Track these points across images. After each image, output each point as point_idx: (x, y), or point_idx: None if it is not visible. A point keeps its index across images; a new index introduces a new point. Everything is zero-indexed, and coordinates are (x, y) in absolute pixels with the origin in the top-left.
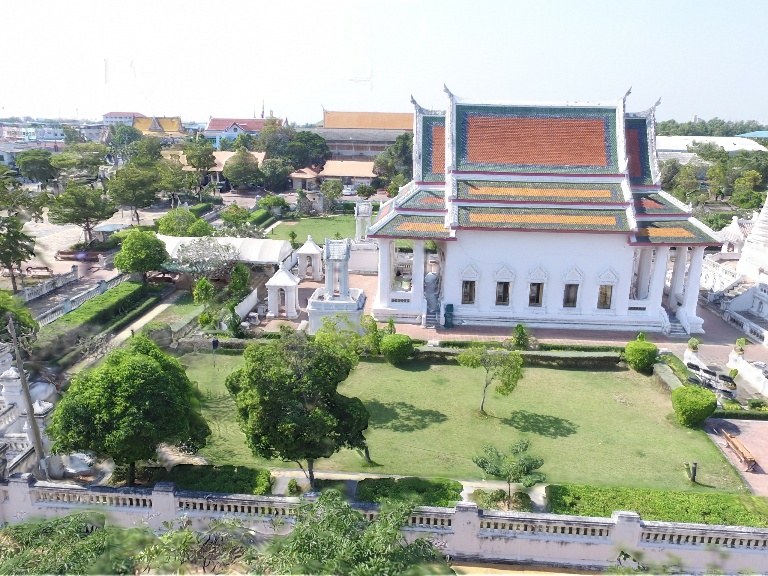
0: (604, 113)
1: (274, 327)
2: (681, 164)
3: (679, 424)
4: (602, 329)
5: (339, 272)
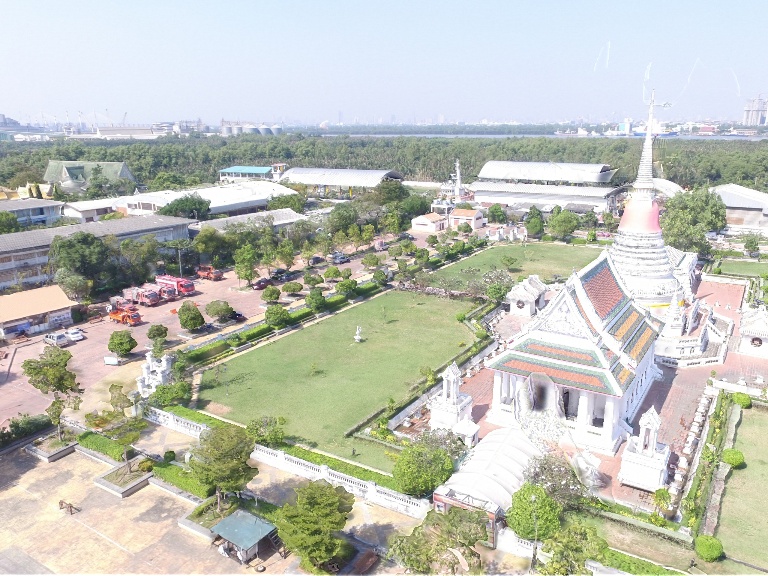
0: None
1: (618, 499)
2: (305, 223)
3: None
4: (648, 392)
5: (657, 432)
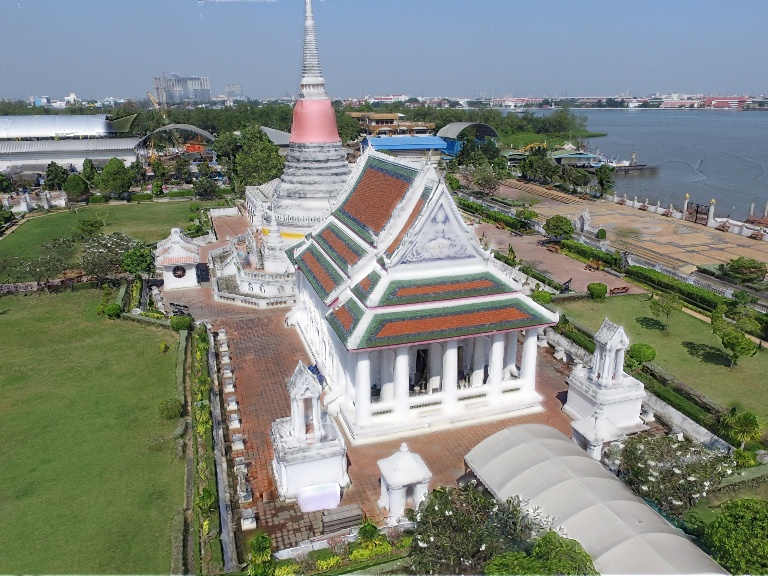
0: None
1: None
2: None
3: (603, 301)
4: None
5: None
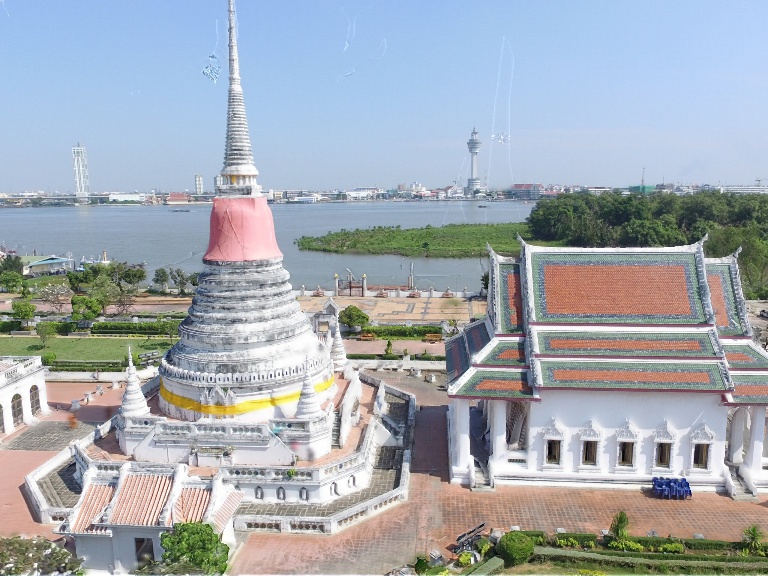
0: (541, 258)
1: None
2: None
3: None
4: None
5: None
